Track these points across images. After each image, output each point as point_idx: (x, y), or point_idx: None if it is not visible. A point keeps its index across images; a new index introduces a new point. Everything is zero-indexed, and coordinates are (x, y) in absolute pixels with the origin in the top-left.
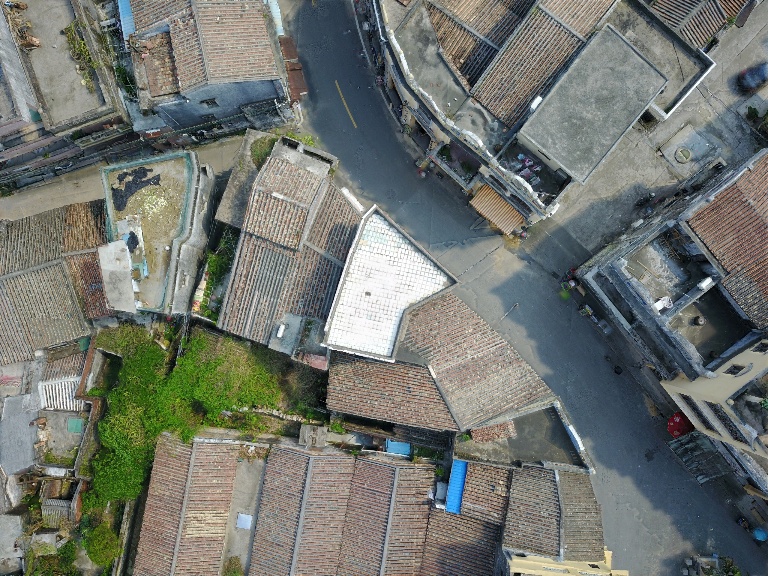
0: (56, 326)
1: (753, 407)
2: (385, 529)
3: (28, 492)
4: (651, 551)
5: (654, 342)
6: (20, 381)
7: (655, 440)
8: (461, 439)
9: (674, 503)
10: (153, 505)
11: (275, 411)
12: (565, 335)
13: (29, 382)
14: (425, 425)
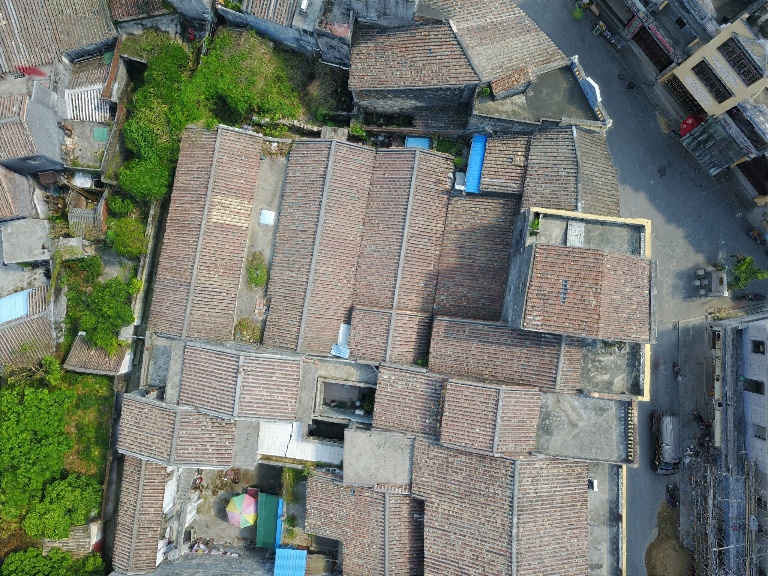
0: (83, 25)
1: (767, 33)
2: (405, 211)
3: (54, 213)
4: (664, 264)
5: (668, 30)
6: (48, 82)
7: (667, 156)
8: (481, 101)
9: (686, 217)
10: (178, 196)
11: (296, 121)
12: (579, 55)
13: (56, 83)
14: (446, 83)
